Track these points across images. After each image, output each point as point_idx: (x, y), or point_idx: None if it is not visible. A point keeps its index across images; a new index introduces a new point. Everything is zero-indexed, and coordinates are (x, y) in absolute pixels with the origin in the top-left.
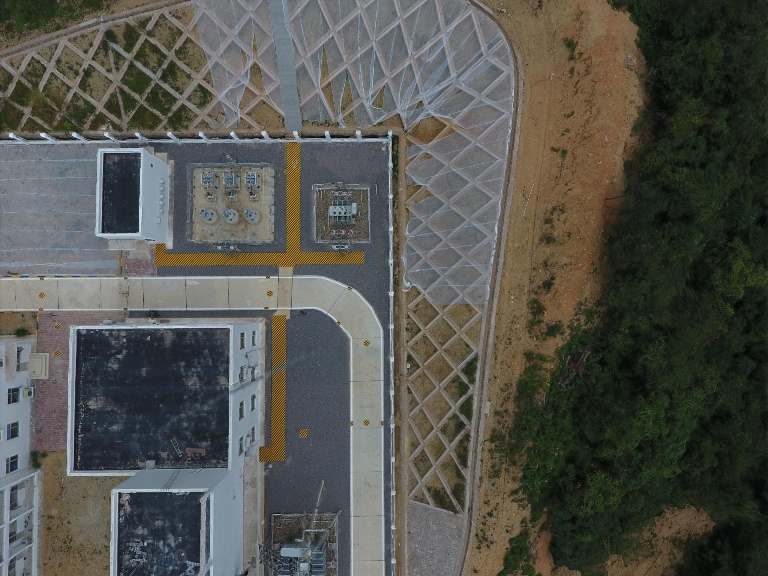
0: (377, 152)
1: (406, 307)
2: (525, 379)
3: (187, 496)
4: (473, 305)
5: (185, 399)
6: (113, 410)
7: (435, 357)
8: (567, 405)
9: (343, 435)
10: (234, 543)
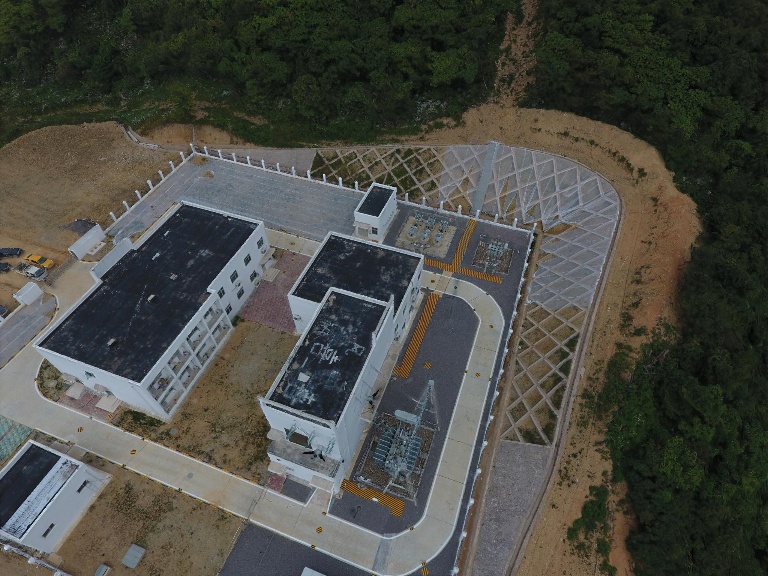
0: (523, 236)
1: (525, 313)
2: (615, 358)
3: (372, 308)
4: (579, 306)
5: (377, 284)
6: (330, 277)
7: (544, 339)
8: (649, 386)
9: (457, 377)
10: (373, 374)
